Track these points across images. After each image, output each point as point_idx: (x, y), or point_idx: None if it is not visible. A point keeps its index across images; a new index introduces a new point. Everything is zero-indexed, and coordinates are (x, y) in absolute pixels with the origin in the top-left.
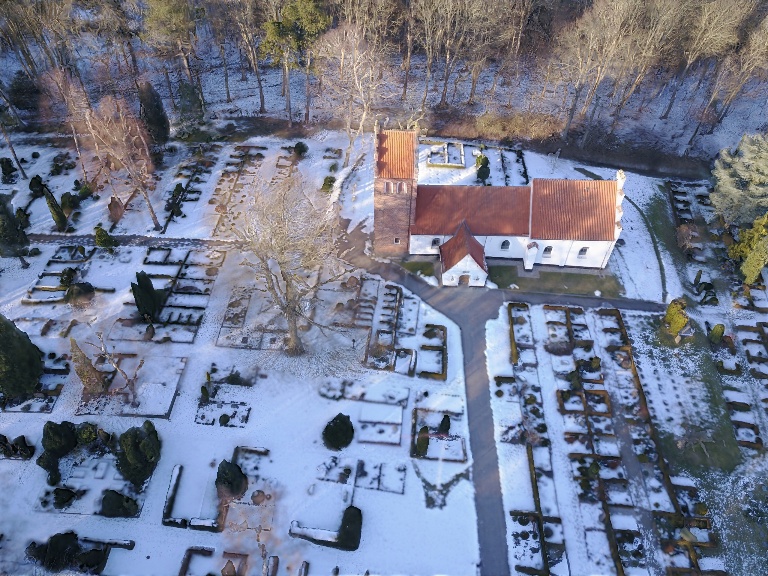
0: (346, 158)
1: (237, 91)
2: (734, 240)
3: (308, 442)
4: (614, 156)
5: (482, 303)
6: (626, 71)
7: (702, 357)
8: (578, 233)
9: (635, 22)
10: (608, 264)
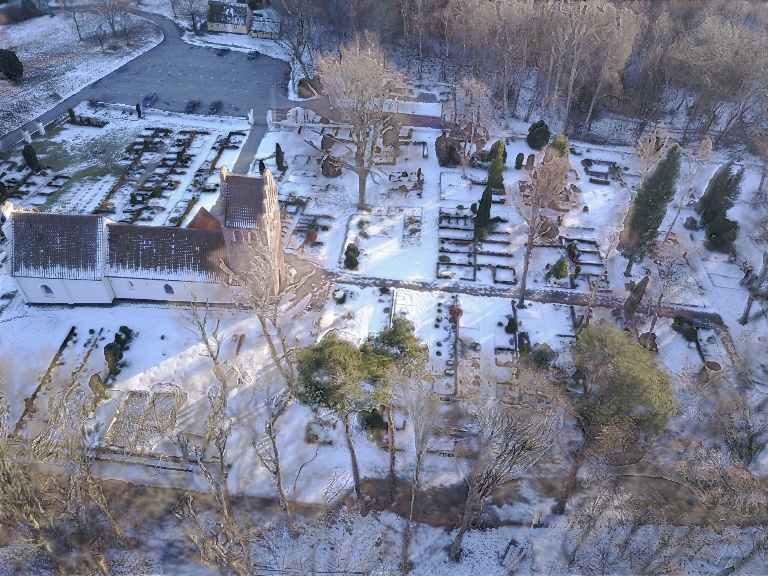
0: None
1: None
2: None
3: None
4: None
5: None
6: None
7: None
8: None
9: None
10: None
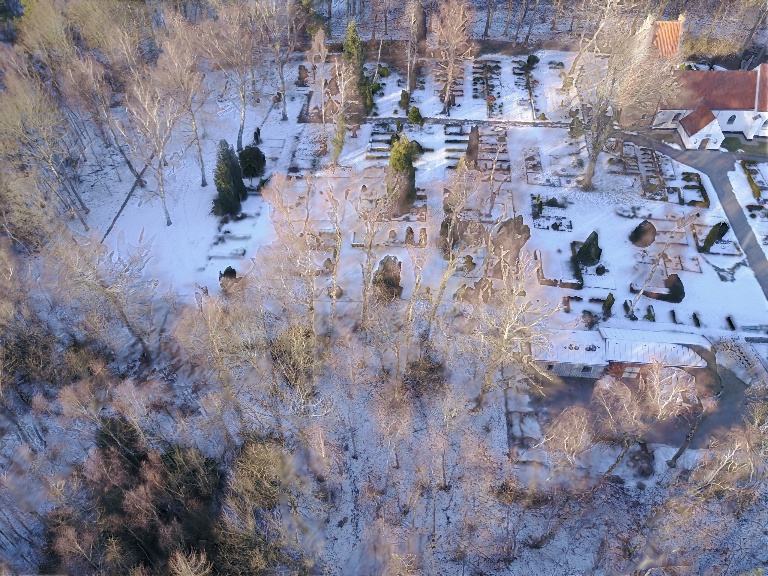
0: (573, 66)
1: None
2: None
3: (621, 242)
4: None
5: (720, 161)
6: None
7: None
8: None
9: None
10: None
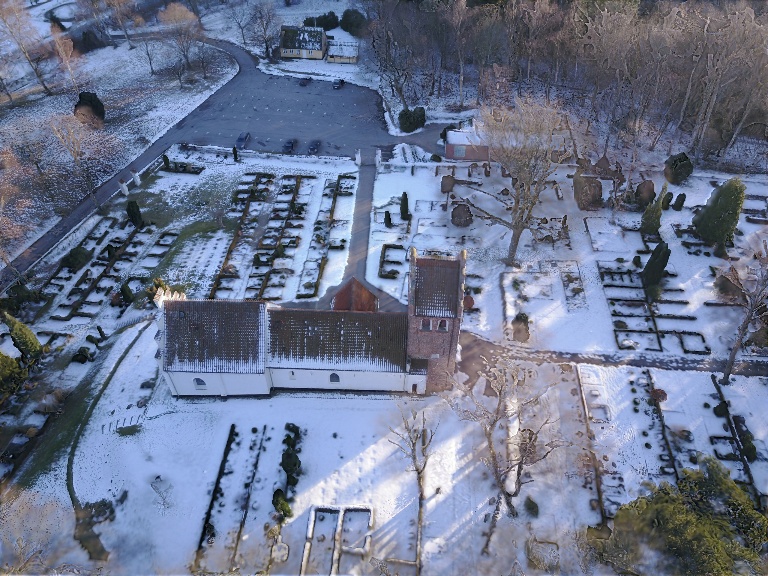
0: None
1: None
2: None
3: None
4: None
5: None
6: None
7: None
8: None
9: None
10: None
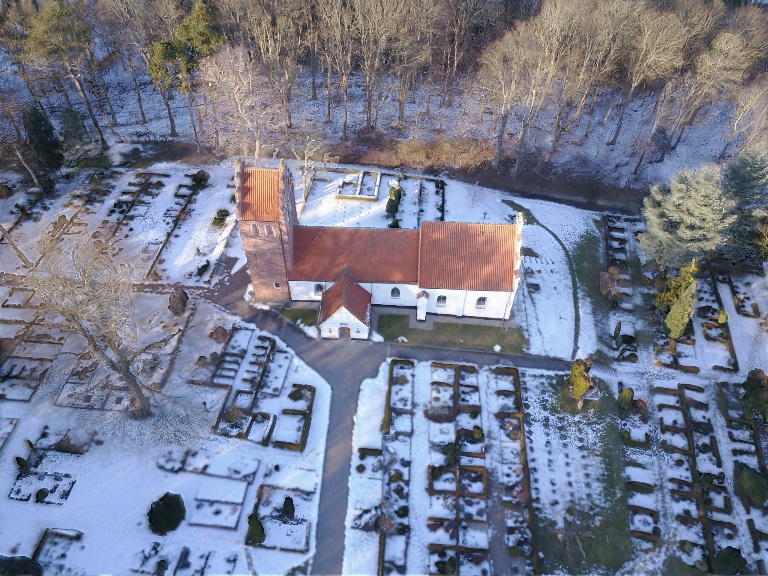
0: None
1: (160, 111)
2: (667, 285)
3: (132, 523)
4: (549, 187)
5: (362, 359)
6: (566, 94)
7: (606, 426)
8: (472, 282)
9: (572, 41)
10: (514, 314)
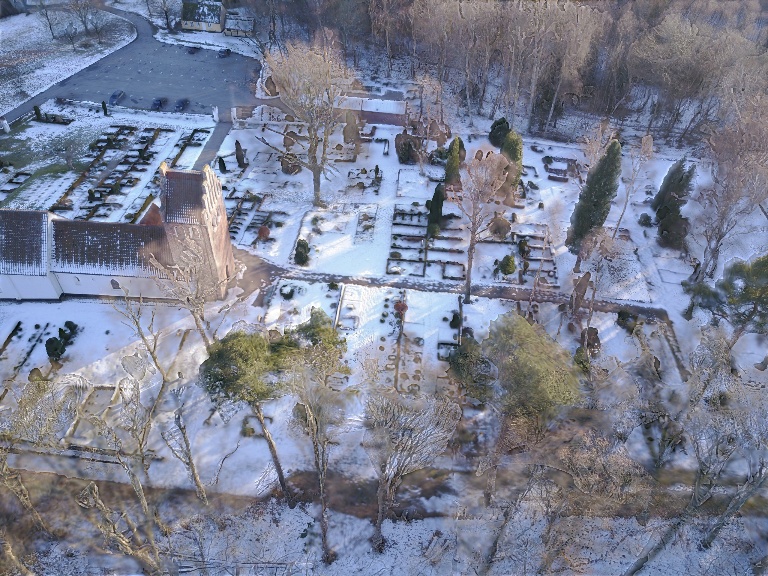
0: None
1: None
2: None
3: None
4: None
5: None
6: None
7: None
8: None
9: None
10: None
